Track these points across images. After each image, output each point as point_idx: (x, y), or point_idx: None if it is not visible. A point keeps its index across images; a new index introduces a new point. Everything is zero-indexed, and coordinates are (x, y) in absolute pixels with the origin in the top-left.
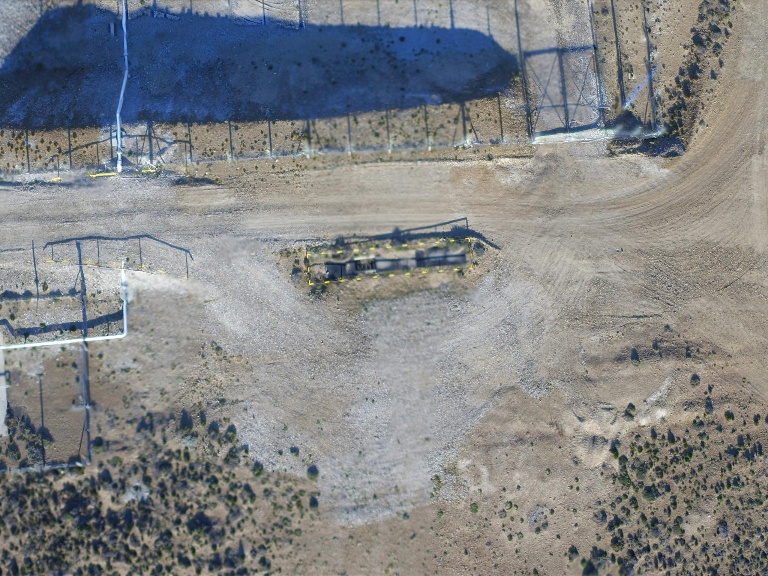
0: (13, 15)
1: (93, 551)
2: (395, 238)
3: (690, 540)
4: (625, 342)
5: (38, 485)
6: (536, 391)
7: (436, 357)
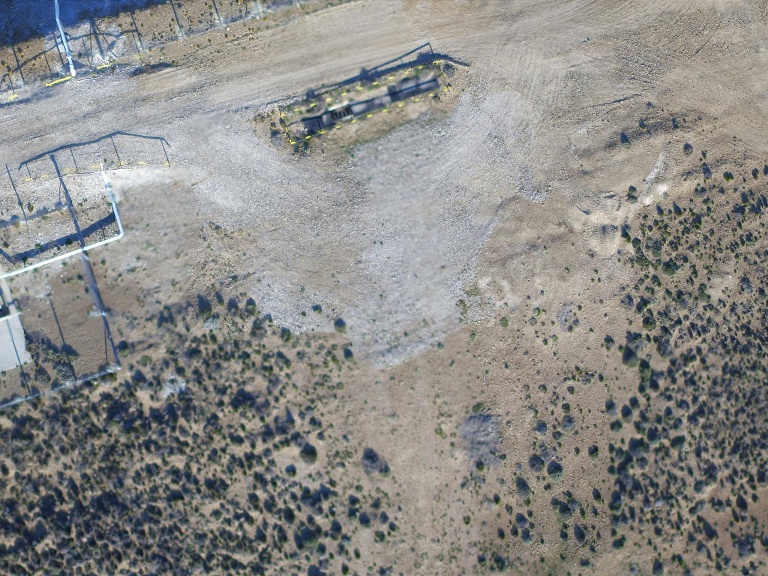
0: None
1: (146, 451)
2: (364, 79)
3: (718, 304)
4: (612, 128)
5: (75, 401)
6: (537, 196)
7: (432, 186)
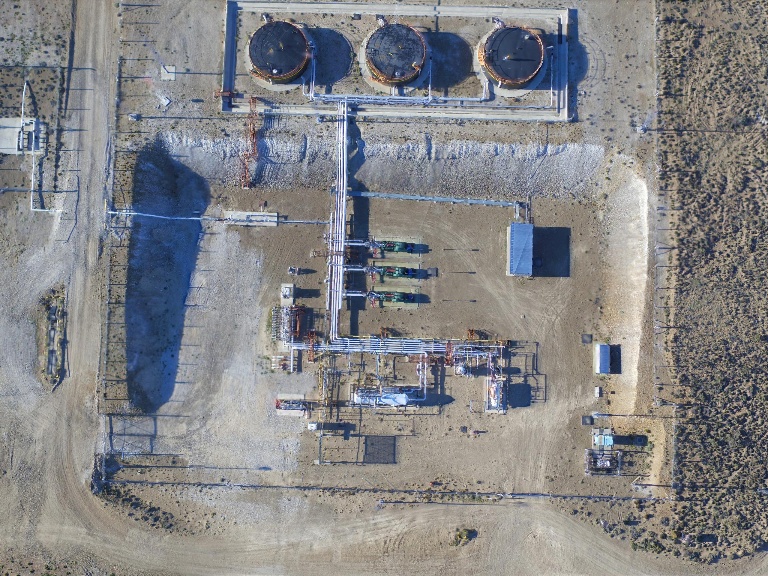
0: (203, 165)
1: None
2: (64, 340)
3: None
4: (1, 449)
5: None
6: None
7: (5, 355)
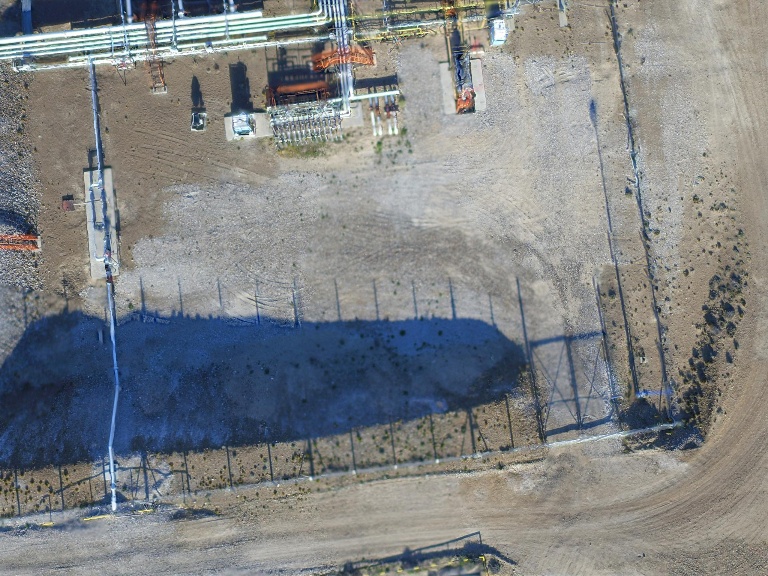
0: None
1: None
2: (406, 560)
3: None
4: None
5: None
6: None
7: None
